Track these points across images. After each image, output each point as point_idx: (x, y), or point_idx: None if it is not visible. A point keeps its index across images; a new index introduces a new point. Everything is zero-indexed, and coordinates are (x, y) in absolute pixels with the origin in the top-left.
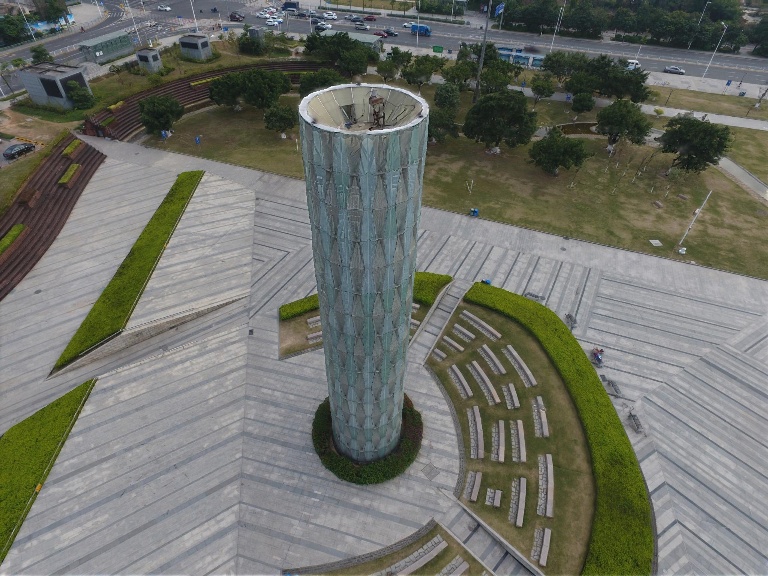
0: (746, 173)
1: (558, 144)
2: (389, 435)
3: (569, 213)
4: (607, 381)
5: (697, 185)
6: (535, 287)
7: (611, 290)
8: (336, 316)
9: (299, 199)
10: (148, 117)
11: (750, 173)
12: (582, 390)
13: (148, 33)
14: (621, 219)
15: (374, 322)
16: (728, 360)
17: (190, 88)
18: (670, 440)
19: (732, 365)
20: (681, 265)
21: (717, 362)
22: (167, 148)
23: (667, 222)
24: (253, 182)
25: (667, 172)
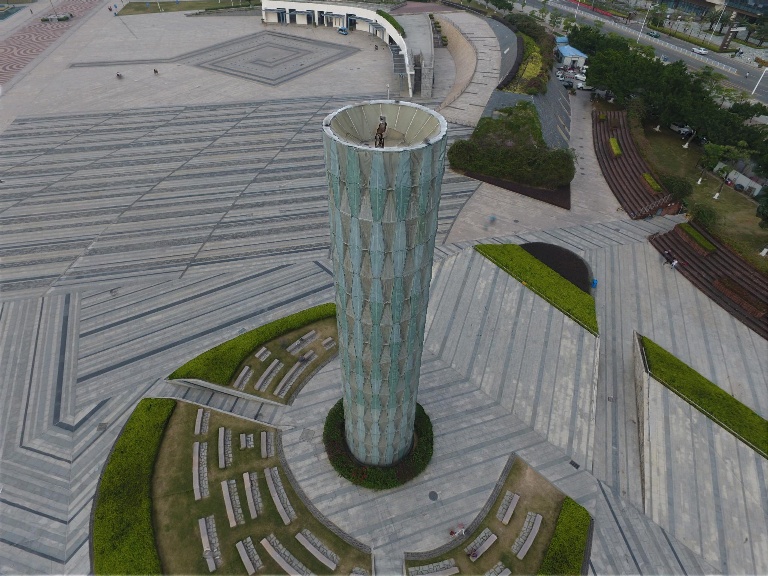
0: None
1: None
2: None
3: None
4: None
5: None
6: None
7: None
8: None
9: None
10: None
11: None
12: None
13: None
14: None
15: None
16: None
17: None
18: None
19: None
20: None
21: None
22: None
23: None
24: None
25: None
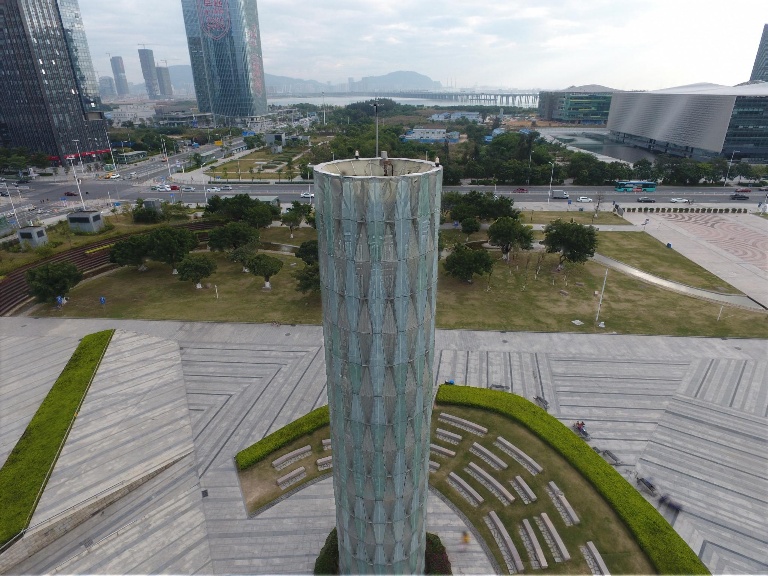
0: (614, 261)
1: (467, 255)
2: (418, 568)
3: (496, 311)
4: (601, 452)
5: (585, 274)
6: (496, 379)
7: (562, 368)
8: (361, 404)
9: (230, 341)
10: (40, 284)
11: (617, 261)
12: (587, 464)
13: (27, 216)
14: (541, 309)
15: (405, 401)
16: (687, 407)
17: (85, 256)
18: (685, 495)
19: (693, 411)
20: (607, 336)
21: (680, 411)
22: (63, 315)
23: (578, 305)
24: (173, 333)
25: (558, 268)
